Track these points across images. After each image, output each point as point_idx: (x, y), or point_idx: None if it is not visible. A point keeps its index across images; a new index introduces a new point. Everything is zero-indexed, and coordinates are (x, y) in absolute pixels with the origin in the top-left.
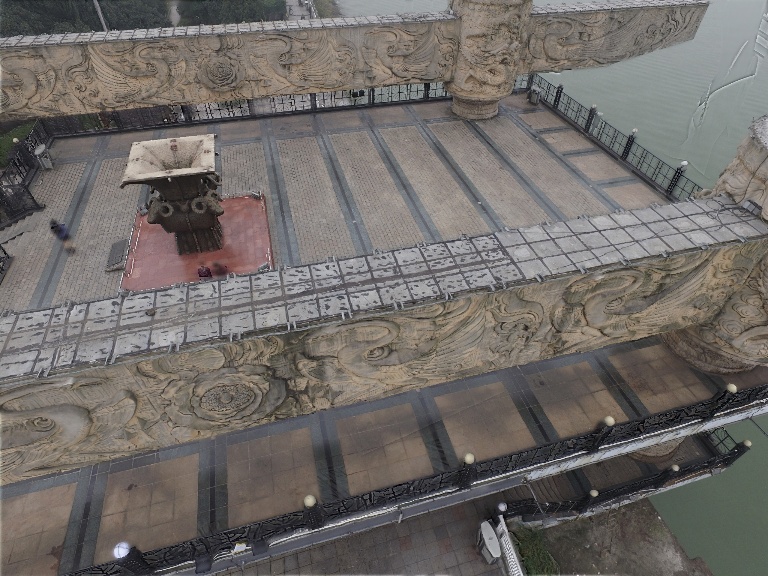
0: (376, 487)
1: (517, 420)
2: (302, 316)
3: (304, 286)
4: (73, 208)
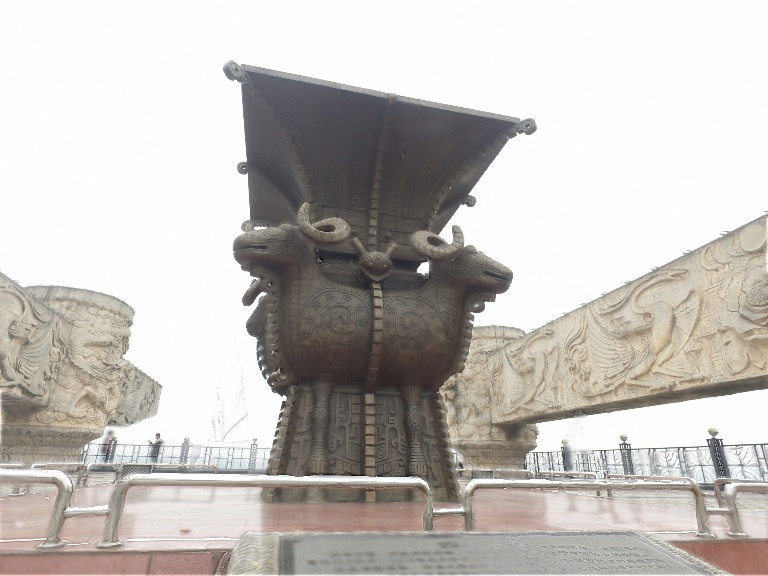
0: None
1: None
2: None
3: None
4: None
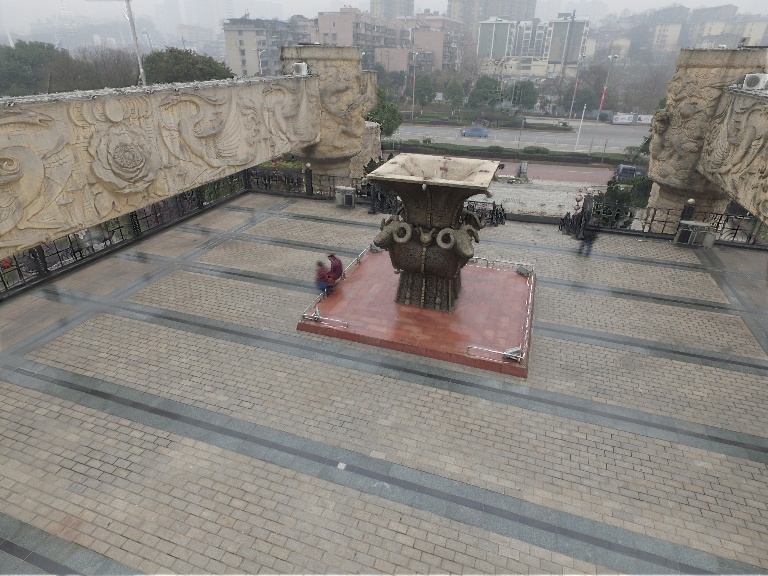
0: (6, 306)
1: None
2: None
3: None
4: (570, 250)
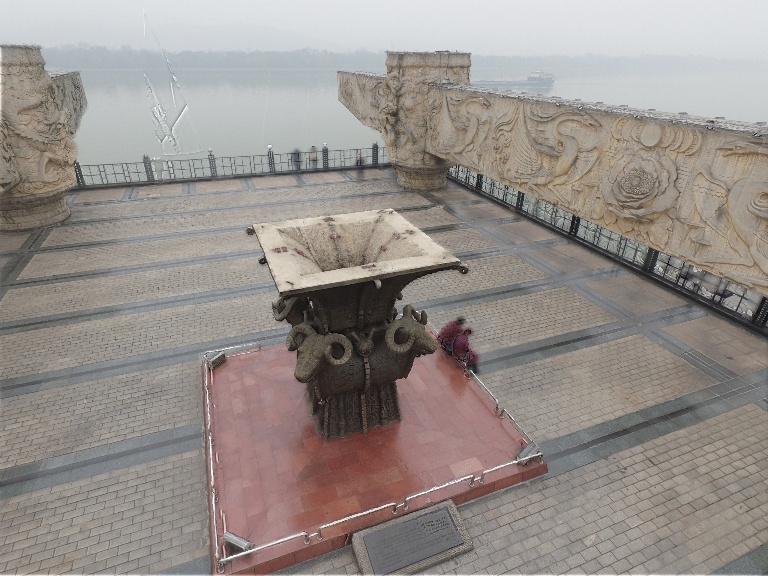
0: None
1: (513, 224)
2: (640, 109)
3: (616, 109)
4: None
